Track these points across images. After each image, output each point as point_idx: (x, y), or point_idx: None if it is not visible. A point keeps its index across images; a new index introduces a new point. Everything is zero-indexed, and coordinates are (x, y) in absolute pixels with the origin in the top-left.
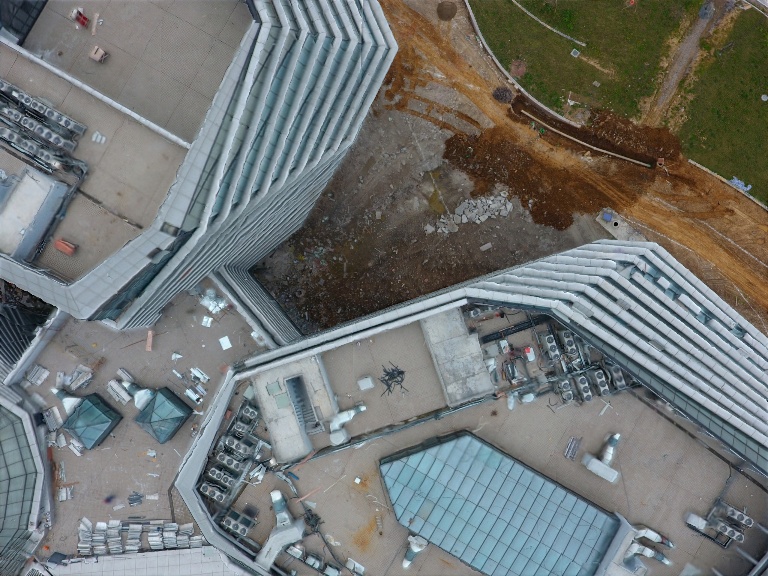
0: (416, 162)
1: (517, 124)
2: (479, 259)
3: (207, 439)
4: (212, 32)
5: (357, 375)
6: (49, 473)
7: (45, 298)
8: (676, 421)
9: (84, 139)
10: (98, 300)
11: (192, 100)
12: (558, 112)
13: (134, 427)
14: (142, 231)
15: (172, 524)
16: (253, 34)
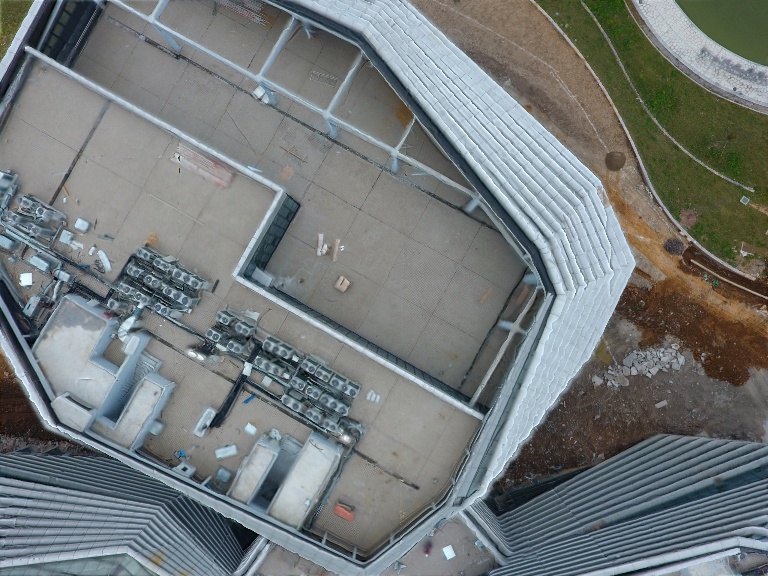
0: None
1: (689, 276)
2: (655, 418)
3: None
4: (455, 258)
5: None
6: None
7: (328, 567)
8: None
9: (358, 397)
10: None
11: (436, 327)
12: (731, 263)
13: None
14: (419, 492)
15: None
16: (547, 306)
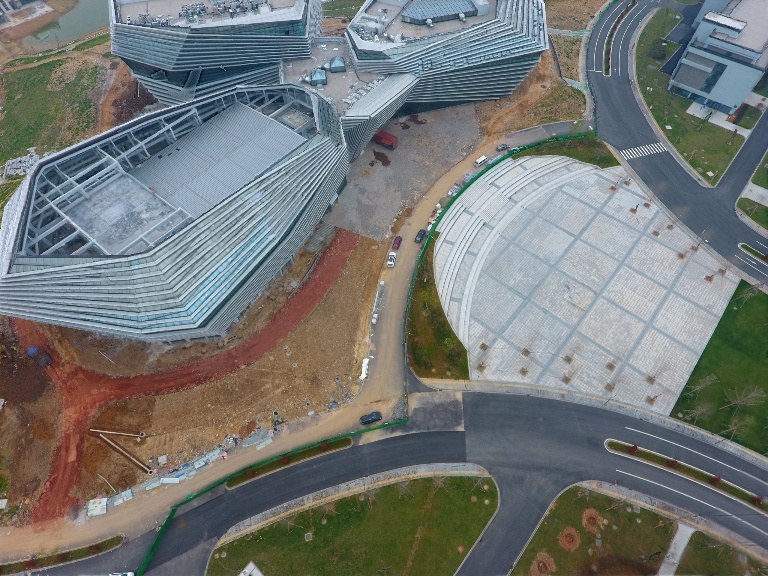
0: None
1: None
2: None
3: None
4: None
5: None
6: None
7: (288, 19)
8: None
9: None
10: None
11: None
12: None
13: None
14: None
15: None
16: None
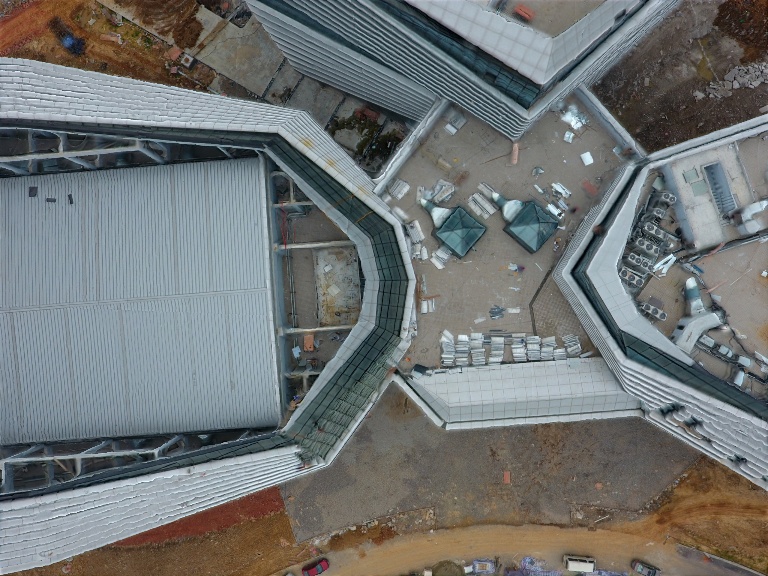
0: (688, 27)
1: None
2: None
3: (625, 224)
4: None
5: (763, 169)
6: None
7: (509, 60)
8: None
9: None
10: (562, 62)
11: None
12: None
13: (496, 241)
14: (594, 1)
15: (534, 337)
16: None
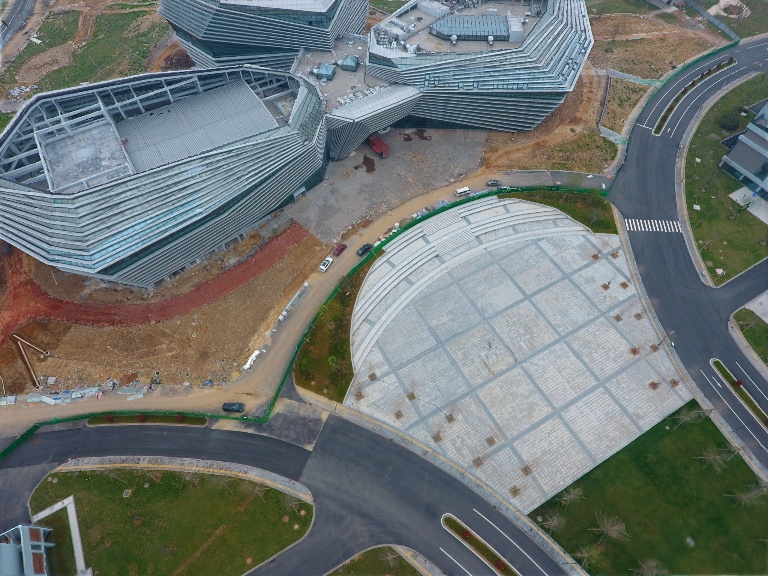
0: None
1: None
2: None
3: None
4: None
5: None
6: None
7: (312, 10)
8: (505, 3)
9: None
10: (327, 6)
11: None
12: None
13: (341, 73)
14: None
15: (371, 88)
16: None
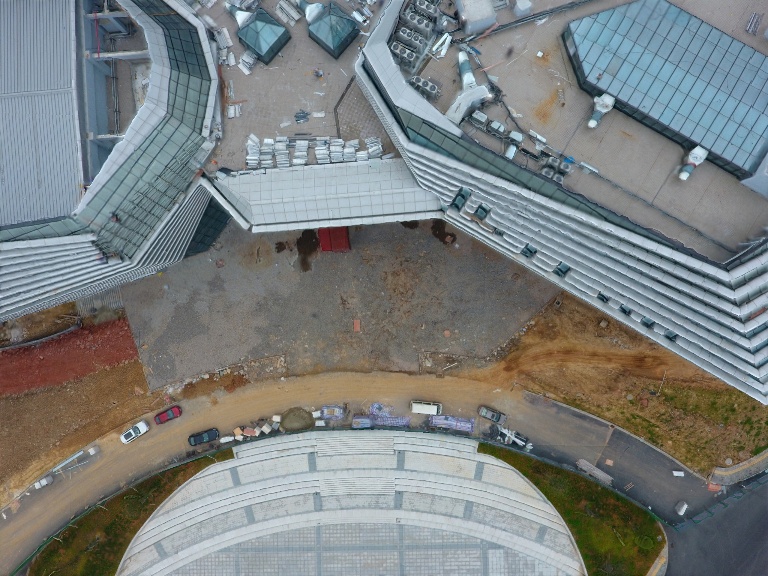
0: None
1: None
2: None
3: (398, 0)
4: None
5: None
6: (219, 89)
7: None
8: None
9: None
10: None
11: None
12: None
13: (302, 47)
14: None
15: (338, 140)
16: None
